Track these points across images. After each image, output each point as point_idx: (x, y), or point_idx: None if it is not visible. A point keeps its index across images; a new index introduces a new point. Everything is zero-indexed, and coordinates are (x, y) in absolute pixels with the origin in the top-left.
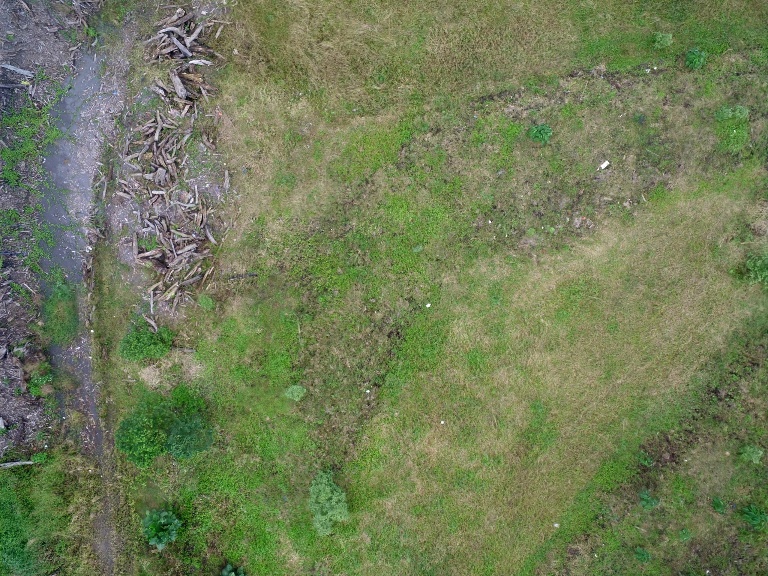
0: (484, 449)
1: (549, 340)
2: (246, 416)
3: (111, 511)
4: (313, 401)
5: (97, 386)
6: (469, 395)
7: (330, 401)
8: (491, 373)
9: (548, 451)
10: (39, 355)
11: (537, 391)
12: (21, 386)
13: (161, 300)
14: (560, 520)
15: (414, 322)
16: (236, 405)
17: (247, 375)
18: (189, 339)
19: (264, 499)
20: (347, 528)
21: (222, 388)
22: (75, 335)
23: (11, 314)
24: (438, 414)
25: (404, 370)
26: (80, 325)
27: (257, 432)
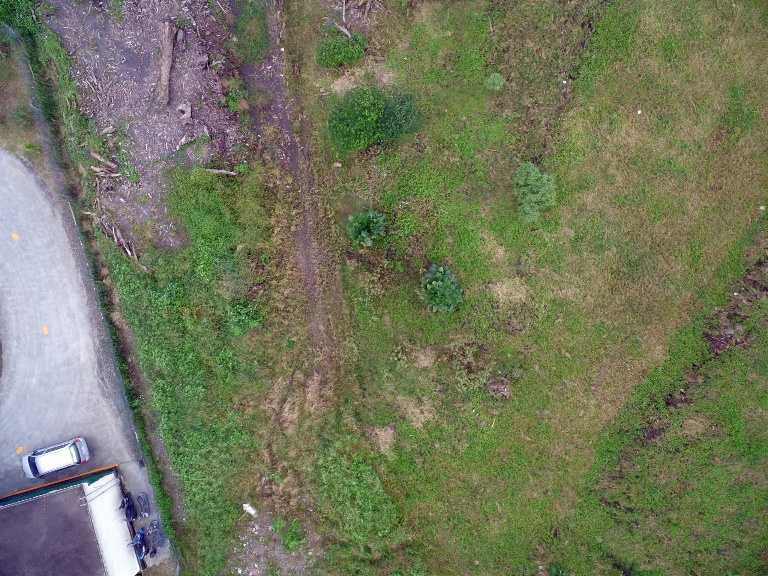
0: (683, 136)
1: (743, 23)
2: (442, 118)
3: (311, 224)
4: (511, 94)
5: (290, 103)
6: (665, 83)
7: (528, 93)
8: (686, 60)
9: (749, 133)
10: (235, 71)
11: (734, 74)
12: (221, 98)
13: (353, 7)
14: (766, 202)
15: (605, 14)
16: (431, 108)
17: (441, 77)
18: (380, 47)
19: (465, 197)
20: (550, 223)
21: (416, 93)
22: (267, 53)
23: (208, 28)
24: (634, 104)
25: (598, 62)
26: (271, 43)
27: (454, 133)
